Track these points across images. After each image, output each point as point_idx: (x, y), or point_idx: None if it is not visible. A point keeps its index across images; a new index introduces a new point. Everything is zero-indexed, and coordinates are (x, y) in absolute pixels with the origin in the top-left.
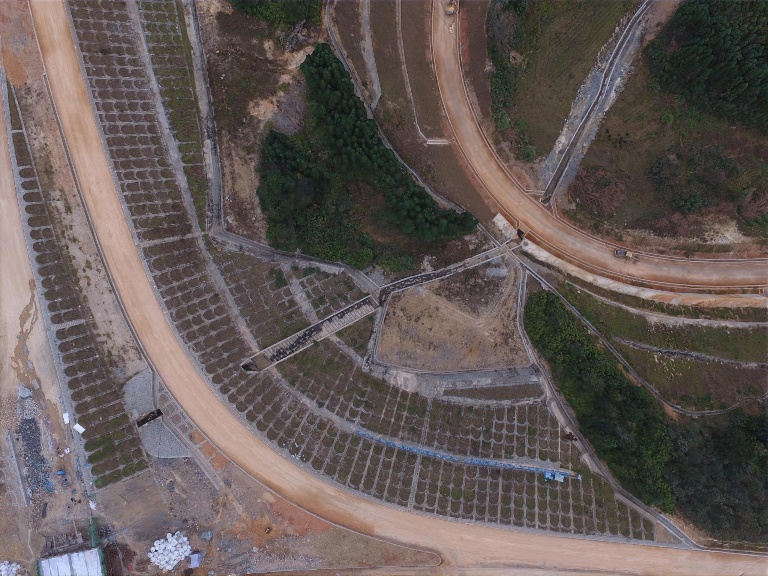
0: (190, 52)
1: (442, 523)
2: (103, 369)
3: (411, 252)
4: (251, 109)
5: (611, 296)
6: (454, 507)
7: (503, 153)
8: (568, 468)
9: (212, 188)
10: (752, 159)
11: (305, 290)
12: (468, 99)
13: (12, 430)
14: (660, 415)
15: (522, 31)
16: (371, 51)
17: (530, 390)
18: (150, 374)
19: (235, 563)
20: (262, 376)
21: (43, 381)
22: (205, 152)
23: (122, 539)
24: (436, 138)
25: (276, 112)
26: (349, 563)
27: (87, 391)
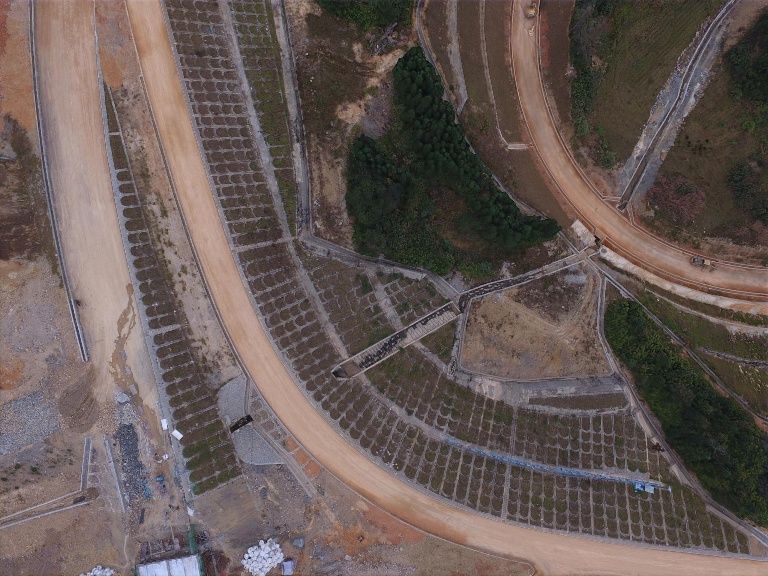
0: (279, 54)
1: (536, 534)
2: (198, 375)
3: (490, 258)
4: (339, 112)
5: (690, 305)
6: (547, 518)
7: (581, 158)
8: (658, 479)
9: (301, 192)
10: None
11: (390, 296)
12: (546, 103)
13: (109, 435)
14: (752, 427)
15: (605, 35)
16: (458, 54)
17: (615, 399)
18: (244, 380)
19: (327, 571)
20: (352, 383)
21: (141, 386)
22: (294, 156)
23: (218, 546)
24: (516, 143)
25: (364, 116)
26: (442, 572)
27: (184, 397)
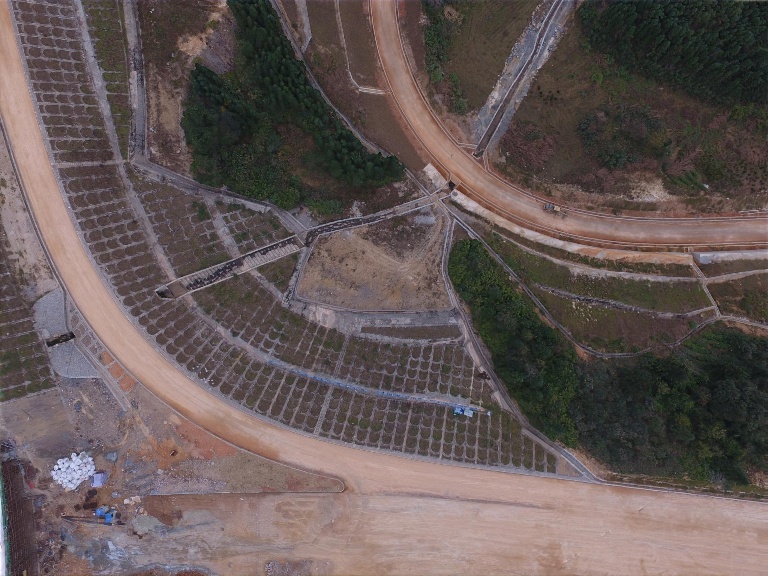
0: None
1: (347, 450)
2: (14, 286)
3: (340, 197)
4: (180, 44)
5: (536, 247)
6: (360, 435)
7: (436, 106)
8: (478, 404)
9: (136, 118)
10: (678, 120)
11: (228, 225)
12: (404, 52)
13: None
14: (569, 354)
15: None
16: None
17: (448, 331)
18: (61, 293)
19: (139, 485)
20: (177, 303)
21: None
22: (131, 83)
23: (24, 454)
24: (369, 87)
25: (205, 49)
26: (253, 487)
27: None
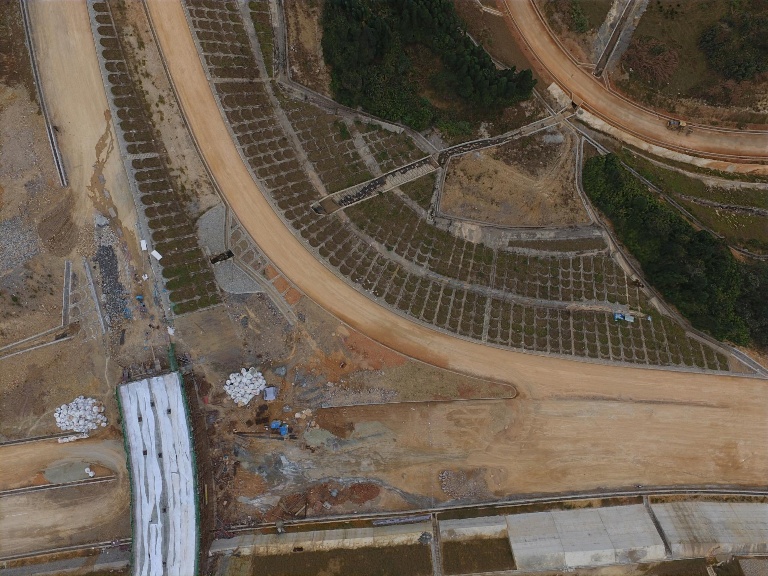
0: None
1: (517, 356)
2: (177, 203)
3: (468, 118)
4: None
5: (667, 162)
6: (528, 341)
7: (556, 25)
8: (637, 310)
9: (278, 36)
10: None
11: (368, 144)
12: None
13: (89, 258)
14: (729, 255)
15: None
16: None
17: (594, 243)
18: (223, 209)
19: (310, 398)
20: (331, 218)
21: (120, 209)
22: (270, 2)
23: (199, 368)
24: (490, 7)
25: None
26: (424, 396)
27: (163, 221)
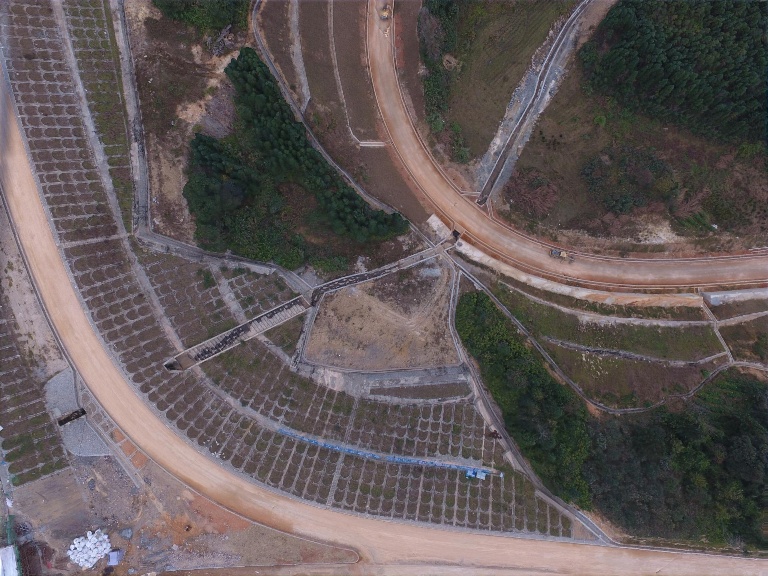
0: (118, 57)
1: (360, 520)
2: (24, 368)
3: (345, 253)
4: (179, 112)
5: (544, 296)
6: (373, 504)
7: (438, 155)
8: (490, 466)
9: (138, 190)
10: (684, 160)
11: (234, 290)
12: (403, 102)
13: None
14: (581, 413)
15: (454, 35)
16: (300, 55)
17: (457, 389)
18: (71, 373)
19: (155, 561)
20: (186, 375)
21: None
22: (132, 155)
23: (40, 537)
24: (370, 140)
25: (204, 115)
26: (268, 560)
27: (6, 390)
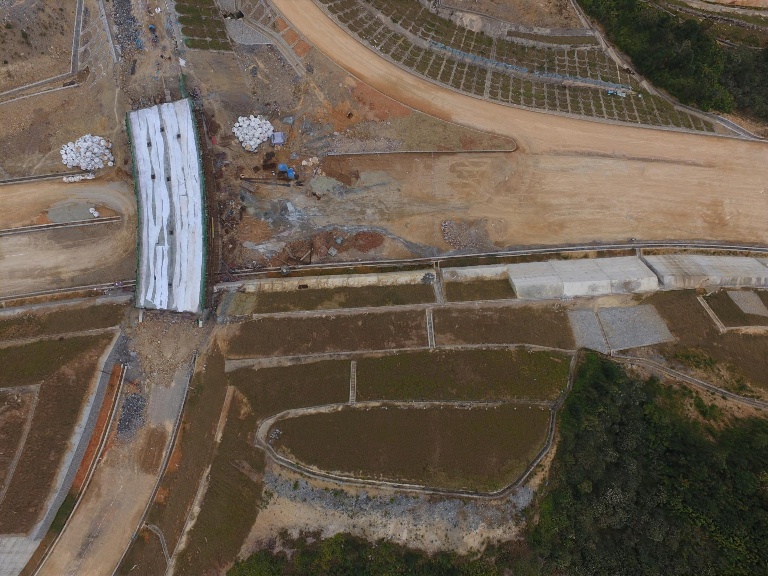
0: None
1: (516, 112)
2: None
3: None
4: None
5: None
6: (527, 101)
7: None
8: (629, 89)
9: None
10: None
11: None
12: None
13: None
14: (713, 38)
15: None
16: None
17: (587, 39)
18: None
19: (316, 147)
20: None
21: None
22: None
23: (209, 104)
24: None
25: None
26: (428, 146)
27: None
